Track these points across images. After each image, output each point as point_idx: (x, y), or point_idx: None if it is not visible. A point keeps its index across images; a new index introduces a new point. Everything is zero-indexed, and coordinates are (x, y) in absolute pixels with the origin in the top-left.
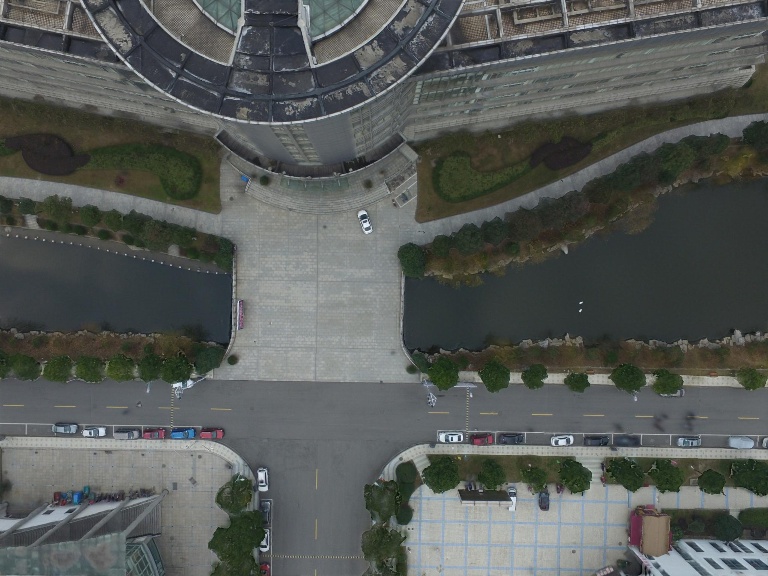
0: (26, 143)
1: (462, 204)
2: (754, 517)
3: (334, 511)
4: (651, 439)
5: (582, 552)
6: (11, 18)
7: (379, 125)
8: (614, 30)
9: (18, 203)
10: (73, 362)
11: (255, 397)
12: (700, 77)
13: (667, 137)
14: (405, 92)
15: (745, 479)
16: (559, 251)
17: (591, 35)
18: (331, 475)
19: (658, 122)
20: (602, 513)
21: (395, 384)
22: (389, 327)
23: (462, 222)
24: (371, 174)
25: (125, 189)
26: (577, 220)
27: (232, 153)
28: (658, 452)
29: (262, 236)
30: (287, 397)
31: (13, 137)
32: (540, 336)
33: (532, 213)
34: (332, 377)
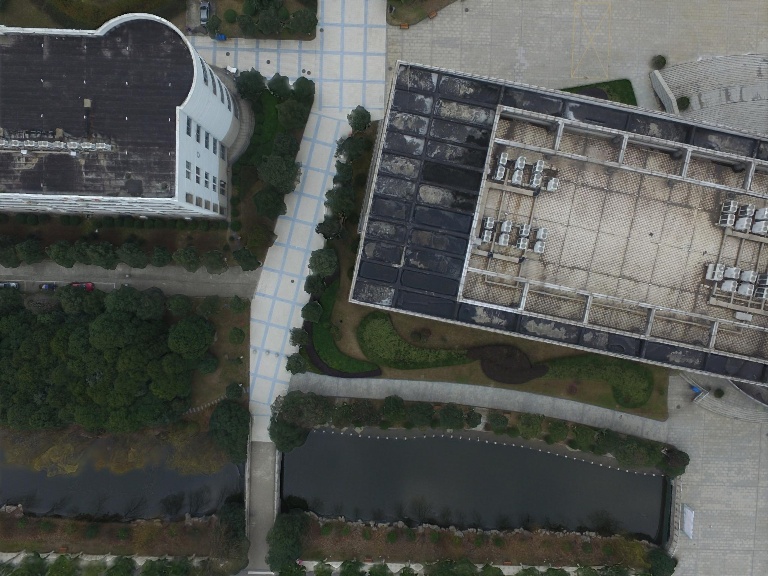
0: (489, 355)
1: None
2: None
3: None
4: None
5: None
6: (691, 335)
7: None
8: None
9: (471, 410)
10: (539, 573)
11: None
12: None
13: None
14: None
15: None
16: None
17: None
18: None
19: None
20: None
21: None
22: None
23: None
24: None
25: (576, 397)
26: None
27: (741, 391)
28: None
29: (706, 443)
30: None
31: (473, 348)
32: None
33: None
34: None
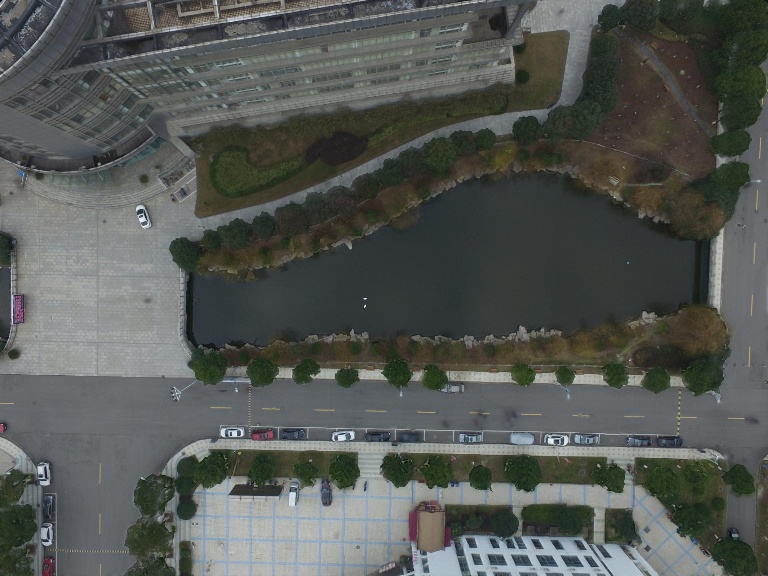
0: None
1: (241, 199)
2: (534, 513)
3: (118, 506)
4: (434, 435)
5: (366, 548)
6: None
7: (89, 118)
8: (269, 23)
9: None
10: None
11: (37, 391)
12: (459, 72)
13: (446, 133)
14: (94, 85)
15: (512, 475)
16: (344, 246)
17: (246, 28)
18: (114, 470)
19: (434, 117)
20: (386, 509)
21: (177, 379)
22: (170, 322)
23: (242, 217)
24: (147, 169)
25: None
26: (352, 215)
27: None
28: (440, 448)
29: (42, 231)
30: (69, 391)
31: None
32: (337, 332)
33: (292, 208)
34: (114, 372)
